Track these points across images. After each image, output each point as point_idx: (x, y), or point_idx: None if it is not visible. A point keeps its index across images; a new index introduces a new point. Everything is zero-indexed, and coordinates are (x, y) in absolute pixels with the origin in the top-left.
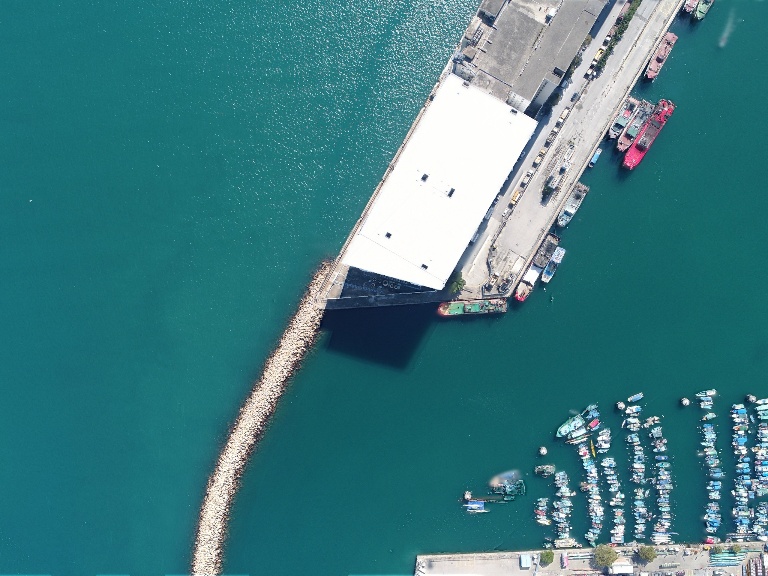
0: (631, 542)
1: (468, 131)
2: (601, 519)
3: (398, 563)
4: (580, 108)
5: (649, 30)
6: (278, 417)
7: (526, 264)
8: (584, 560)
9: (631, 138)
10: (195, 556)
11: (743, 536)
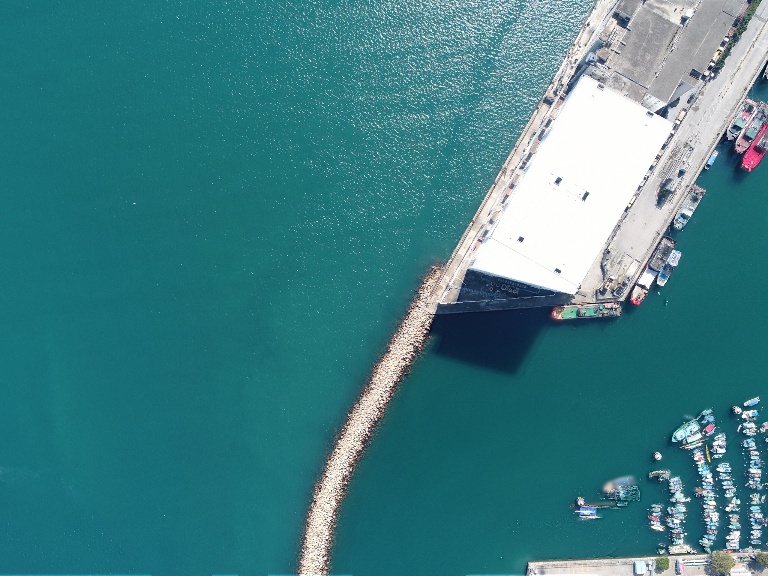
0: (747, 548)
1: (603, 134)
2: (716, 525)
3: (508, 570)
4: (696, 110)
5: (767, 31)
6: (386, 423)
7: (641, 267)
8: (699, 566)
9: (749, 140)
10: (302, 563)
11: None
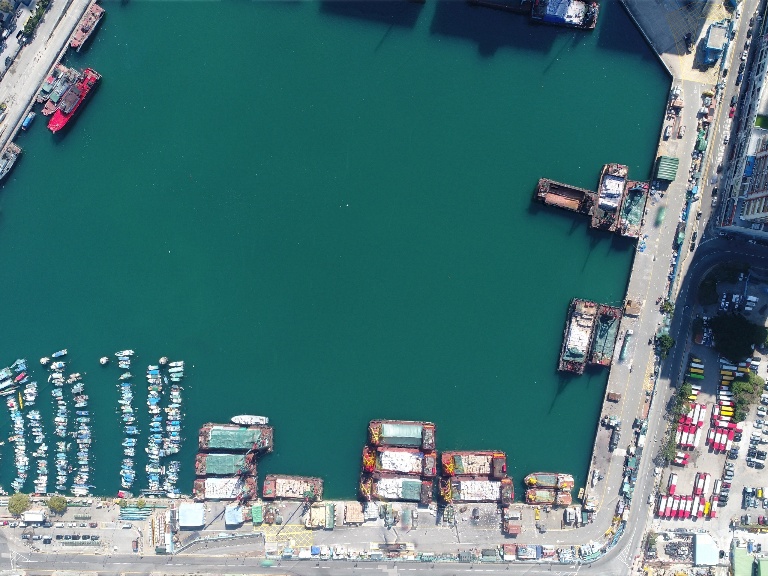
0: (53, 493)
1: None
2: (26, 469)
3: None
4: (13, 72)
5: (79, 1)
6: None
7: None
8: (7, 507)
9: (54, 103)
10: None
11: (155, 493)
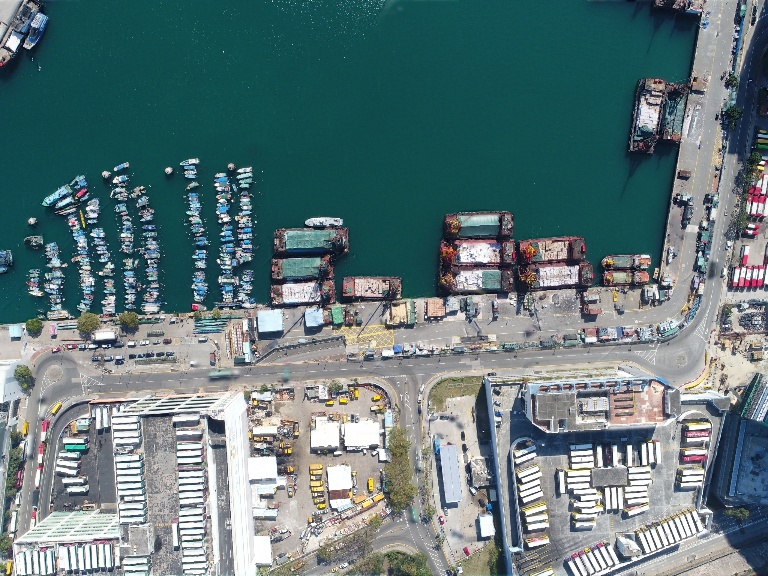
0: (122, 312)
1: None
2: (92, 290)
3: None
4: None
5: None
6: None
7: (8, 31)
8: (74, 330)
9: None
10: None
11: (229, 305)
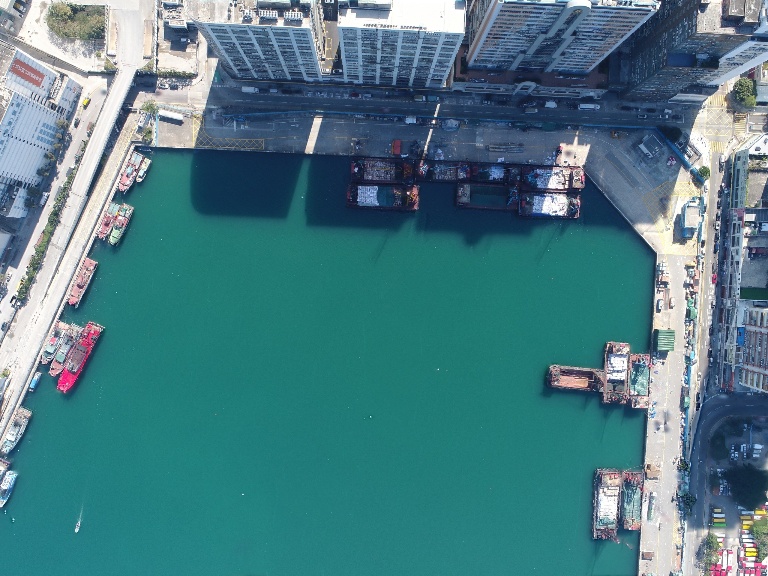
0: None
1: None
2: None
3: None
4: (12, 336)
5: (69, 257)
6: None
7: None
8: None
9: (61, 363)
10: None
11: None
